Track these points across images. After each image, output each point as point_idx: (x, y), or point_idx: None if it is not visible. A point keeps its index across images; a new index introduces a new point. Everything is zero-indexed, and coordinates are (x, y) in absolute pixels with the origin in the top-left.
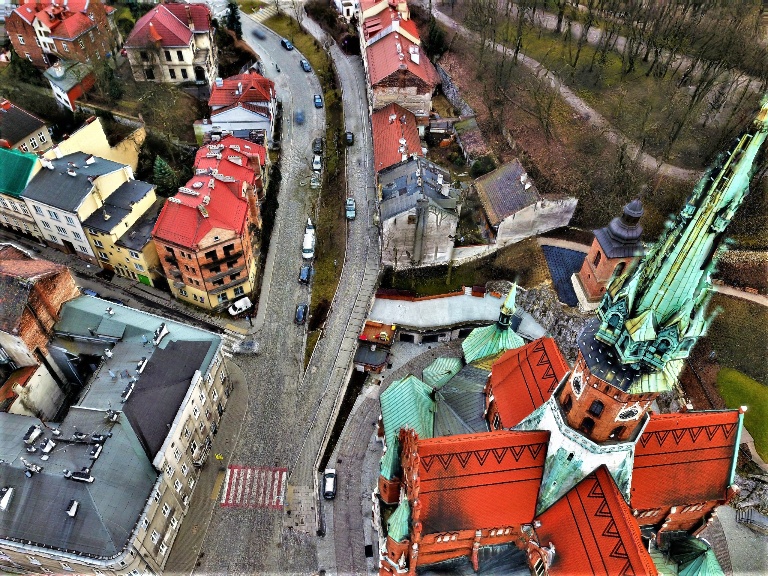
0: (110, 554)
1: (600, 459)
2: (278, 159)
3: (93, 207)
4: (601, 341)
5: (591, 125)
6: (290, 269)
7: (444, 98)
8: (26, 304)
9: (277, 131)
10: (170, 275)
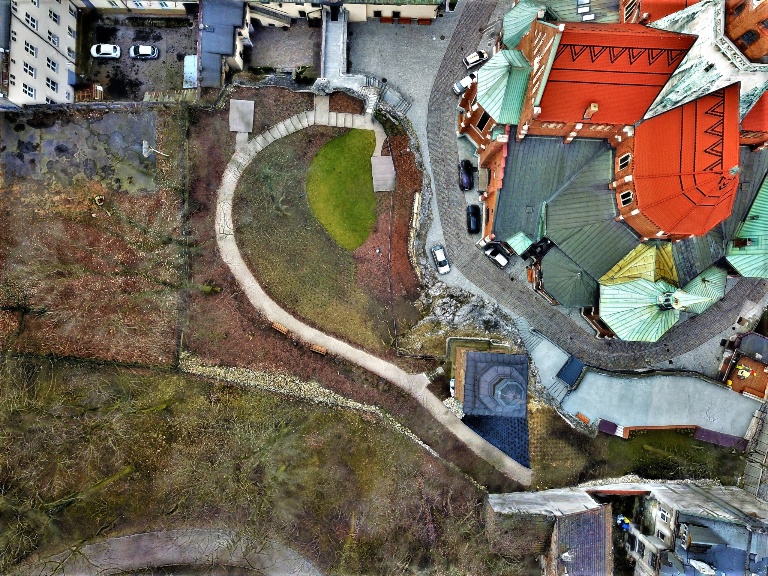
0: None
1: None
2: None
3: None
4: None
5: None
6: None
7: None
8: None
9: None
10: None
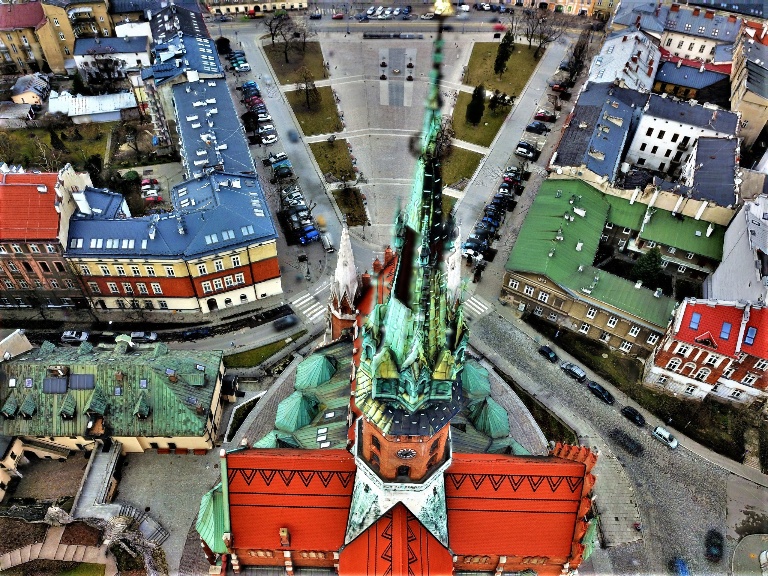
0: None
1: None
2: None
3: None
4: None
5: None
6: None
7: None
8: None
9: None
10: None
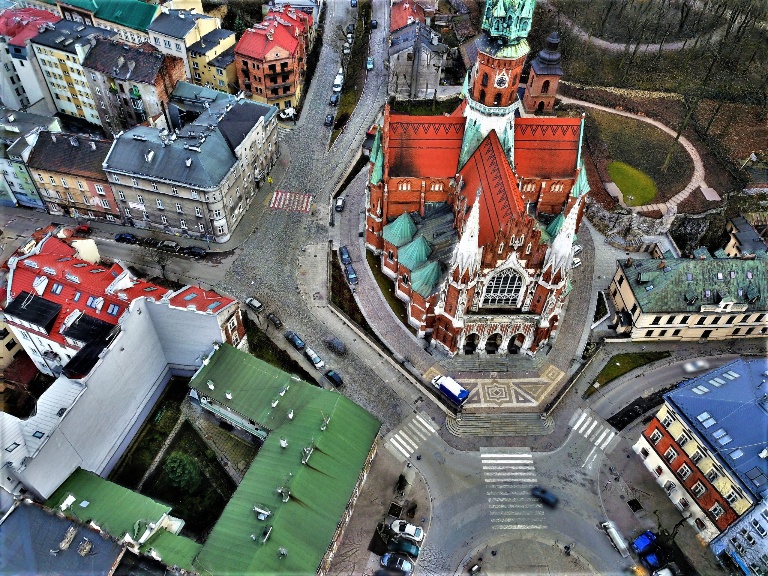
0: (209, 186)
1: (491, 124)
2: (321, 34)
3: (194, 39)
4: (484, 29)
5: (551, 16)
6: (324, 97)
7: (449, 4)
8: (160, 67)
9: (321, 18)
10: (243, 87)
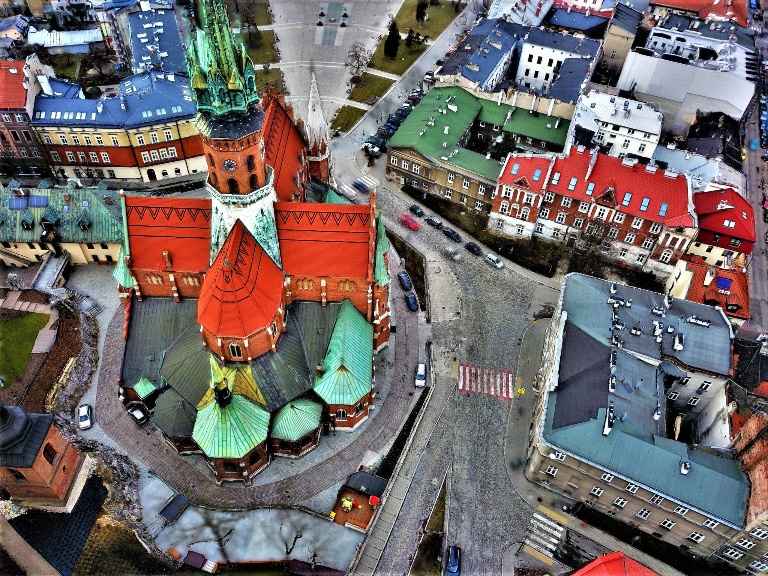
0: (575, 275)
1: None
2: None
3: None
4: None
5: None
6: None
7: None
8: None
9: None
10: None
